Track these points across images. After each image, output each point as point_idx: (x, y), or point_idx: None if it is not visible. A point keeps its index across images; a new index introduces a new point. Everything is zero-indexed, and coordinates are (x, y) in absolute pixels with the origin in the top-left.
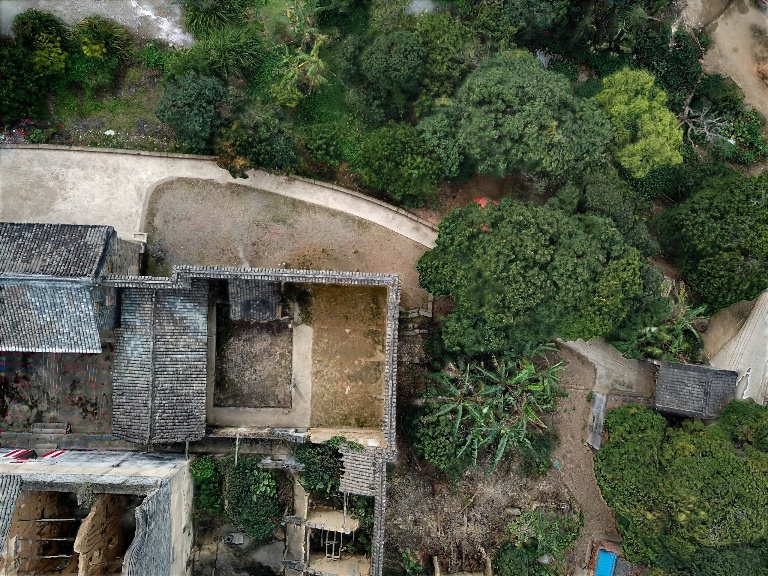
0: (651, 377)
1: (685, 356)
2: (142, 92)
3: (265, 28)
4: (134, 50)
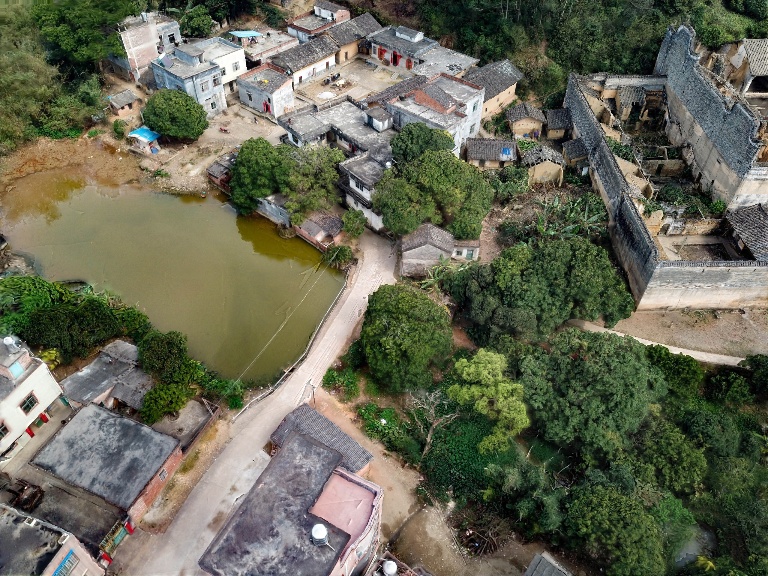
0: None
1: (414, 283)
2: None
3: None
4: None
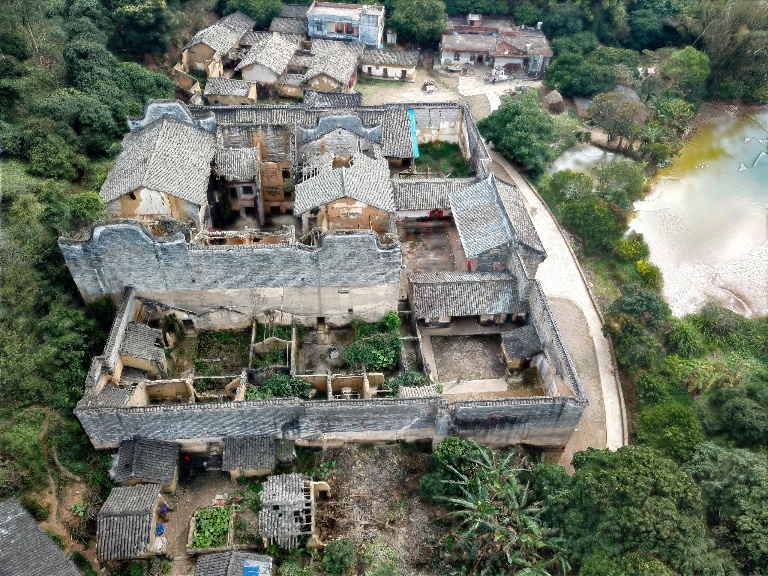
0: None
1: None
2: None
3: None
4: None
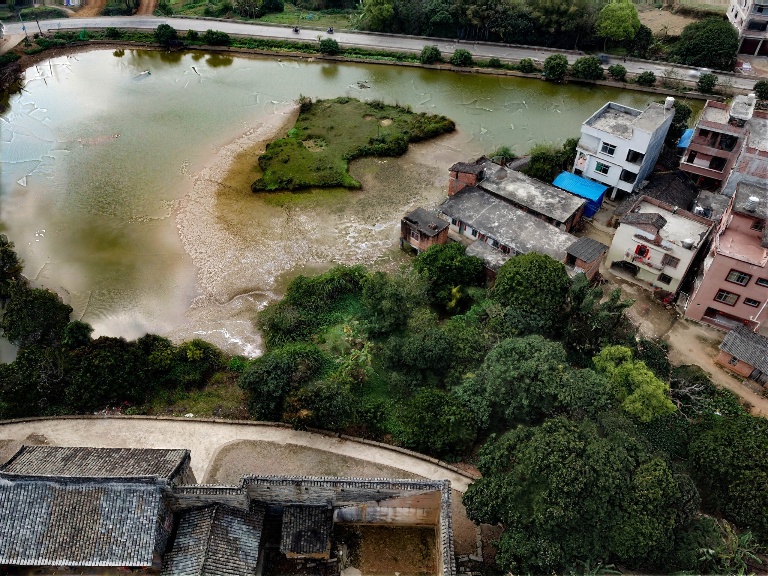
0: None
1: None
2: (222, 387)
3: (324, 346)
4: (222, 360)
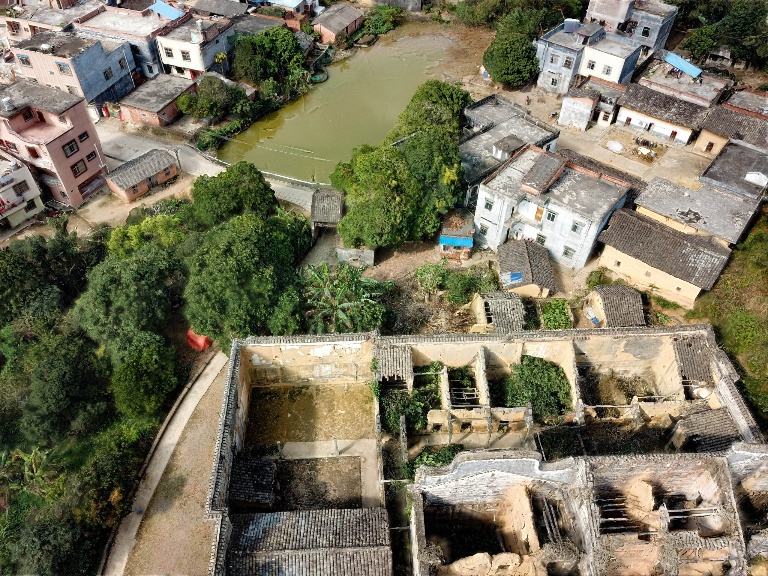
0: (327, 239)
1: None
2: None
3: None
4: None
